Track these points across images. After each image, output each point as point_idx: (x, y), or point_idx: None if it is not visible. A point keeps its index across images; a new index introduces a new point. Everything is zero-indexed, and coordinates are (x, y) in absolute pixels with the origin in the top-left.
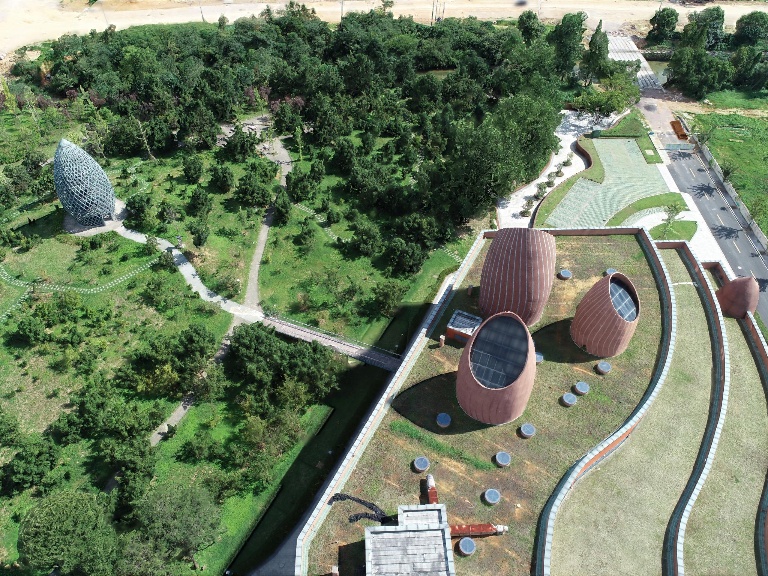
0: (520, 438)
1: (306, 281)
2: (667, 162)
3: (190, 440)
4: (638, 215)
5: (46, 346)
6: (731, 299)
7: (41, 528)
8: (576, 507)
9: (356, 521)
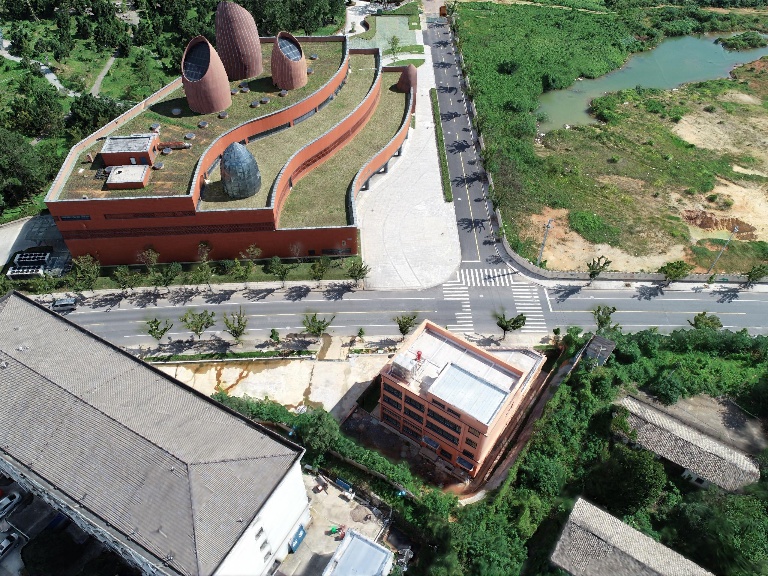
0: (219, 118)
1: (135, 85)
2: (424, 29)
3: (35, 147)
4: (386, 56)
5: None
6: (401, 80)
7: None
8: None
9: None
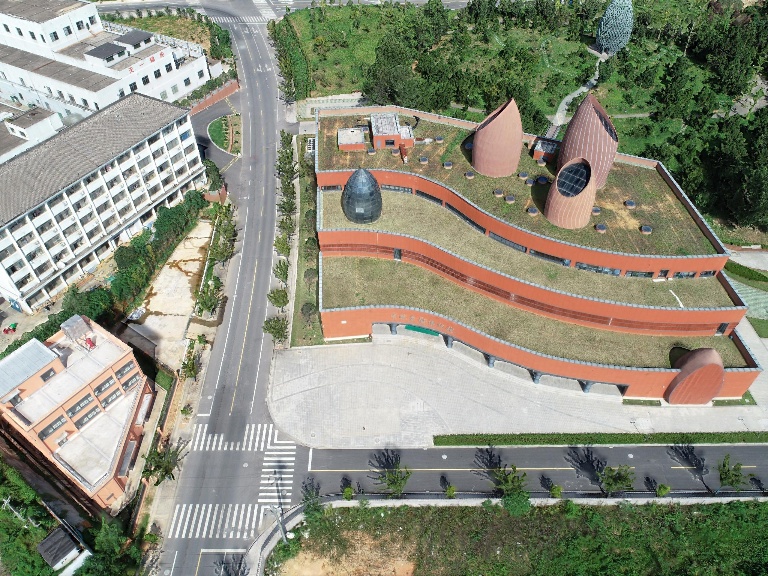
0: (464, 173)
1: None
2: None
3: None
4: None
5: (503, 61)
6: None
7: (387, 43)
8: (430, 207)
9: (406, 124)
